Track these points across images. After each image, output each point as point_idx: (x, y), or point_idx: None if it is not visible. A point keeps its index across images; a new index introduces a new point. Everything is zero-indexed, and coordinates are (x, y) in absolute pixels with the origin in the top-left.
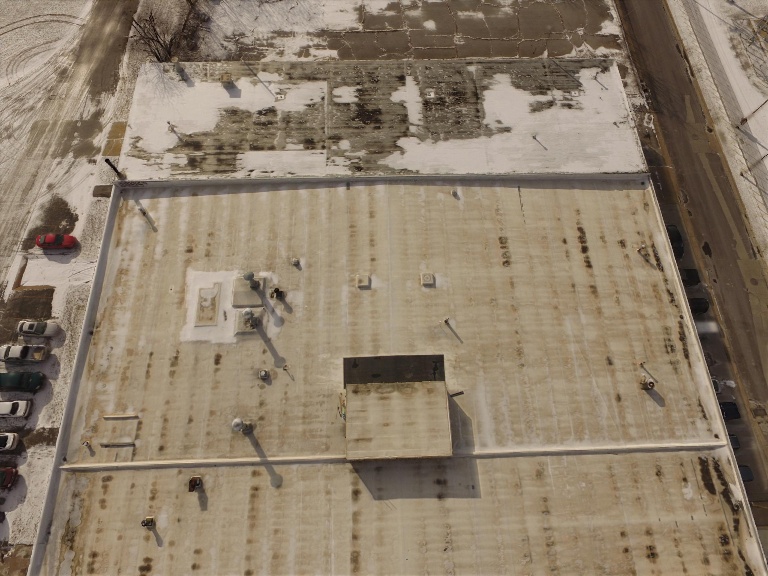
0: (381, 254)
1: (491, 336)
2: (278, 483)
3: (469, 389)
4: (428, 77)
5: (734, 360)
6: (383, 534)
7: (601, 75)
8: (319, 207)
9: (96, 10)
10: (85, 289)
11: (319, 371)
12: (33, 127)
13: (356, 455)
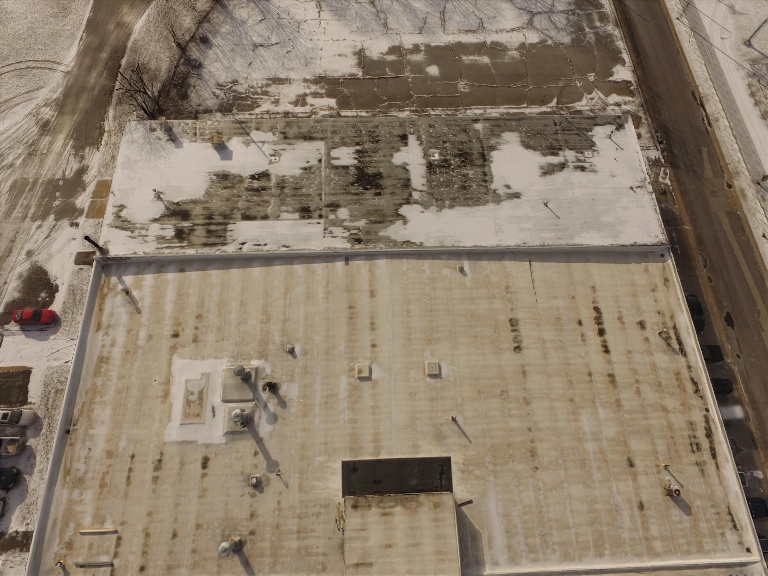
0: (382, 339)
1: (502, 434)
2: None
3: (479, 497)
4: (432, 136)
5: (761, 447)
6: None
7: (616, 133)
8: (316, 285)
9: (81, 55)
10: (64, 370)
11: (315, 476)
12: (12, 186)
13: None
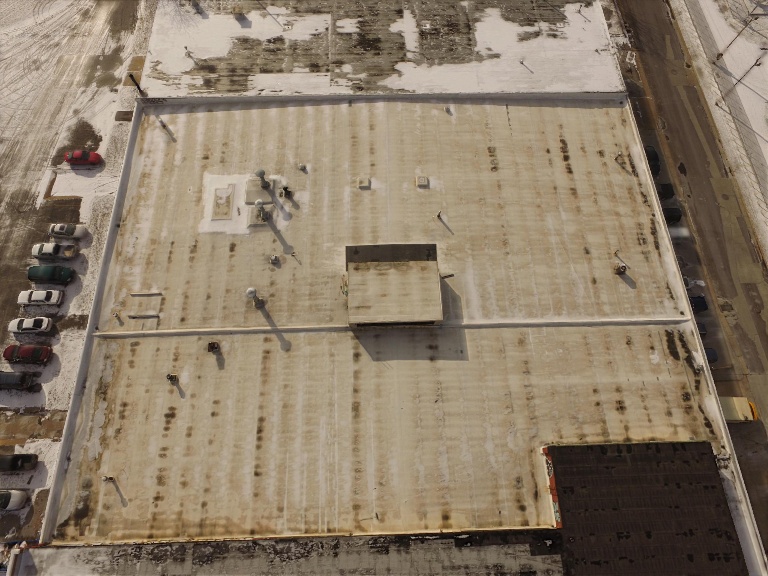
0: (380, 160)
1: (479, 229)
2: (287, 347)
3: (459, 272)
4: (424, 11)
5: (704, 263)
6: (381, 388)
7: (585, 9)
8: (324, 121)
9: None
10: (110, 199)
11: (324, 257)
12: (59, 60)
13: (357, 319)
